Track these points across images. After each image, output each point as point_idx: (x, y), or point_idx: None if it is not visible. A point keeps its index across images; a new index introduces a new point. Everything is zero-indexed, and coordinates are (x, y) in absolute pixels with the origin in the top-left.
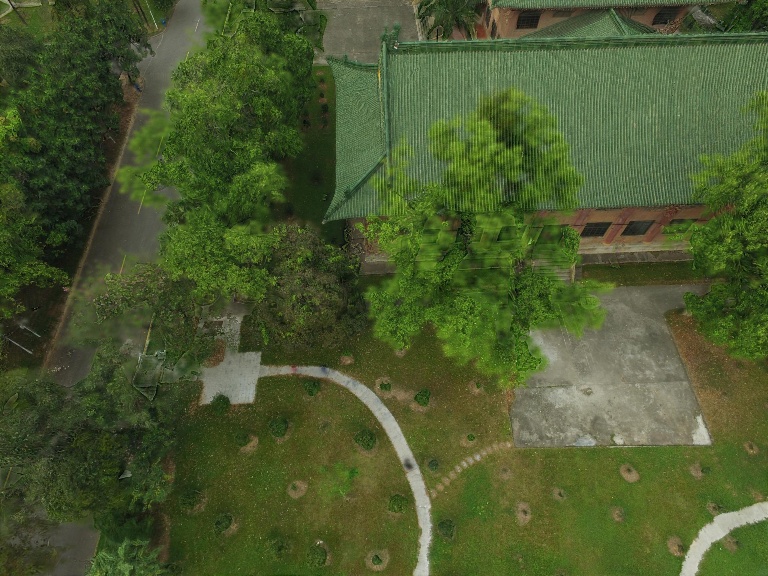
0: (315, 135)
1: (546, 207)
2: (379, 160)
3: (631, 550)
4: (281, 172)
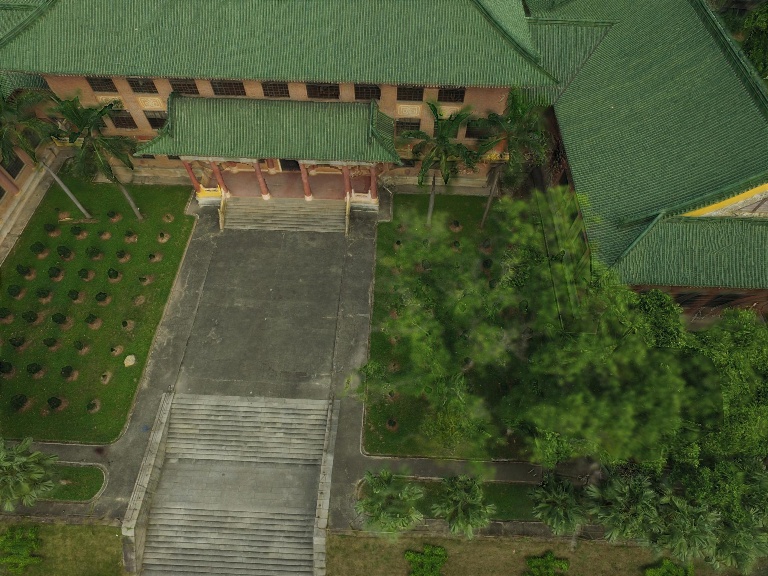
0: (547, 376)
1: None
2: None
3: None
4: (634, 423)
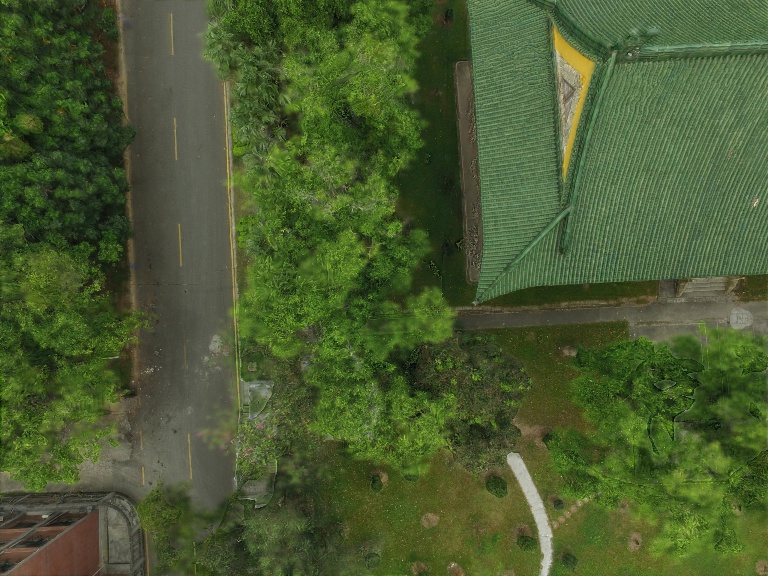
0: None
1: (759, 272)
2: (558, 220)
3: (724, 571)
4: None
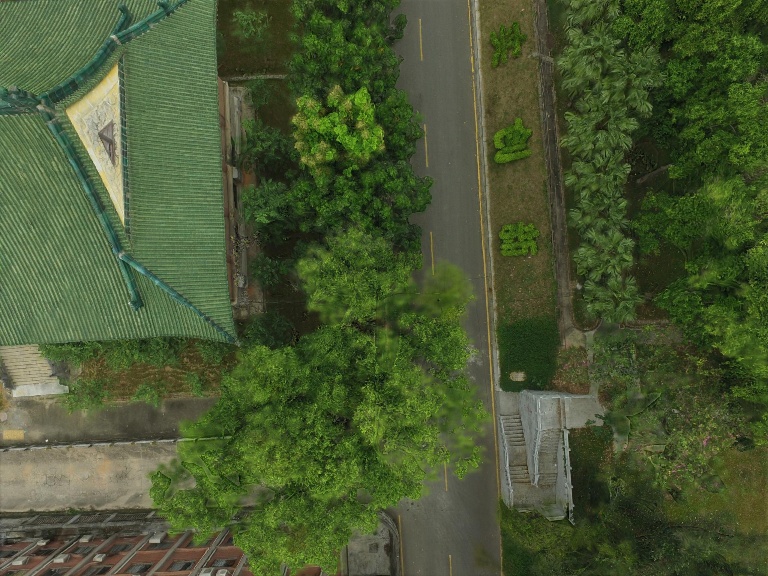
0: None
1: None
2: None
3: None
4: None
